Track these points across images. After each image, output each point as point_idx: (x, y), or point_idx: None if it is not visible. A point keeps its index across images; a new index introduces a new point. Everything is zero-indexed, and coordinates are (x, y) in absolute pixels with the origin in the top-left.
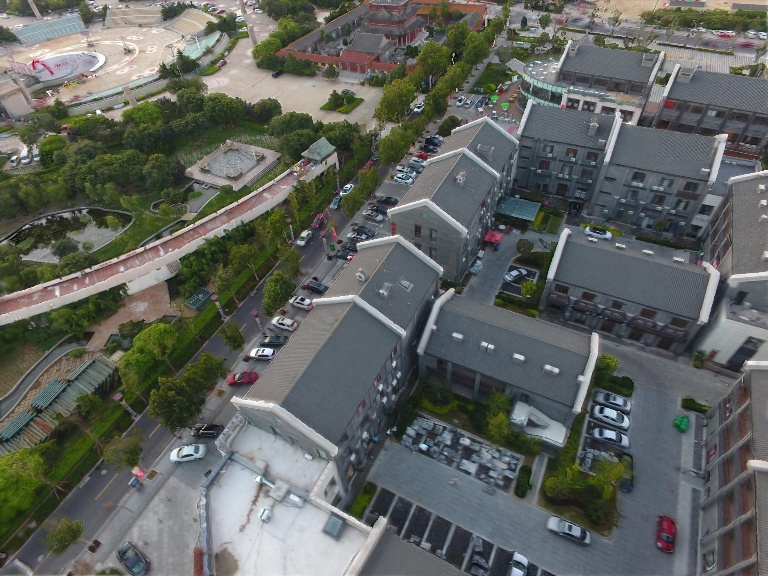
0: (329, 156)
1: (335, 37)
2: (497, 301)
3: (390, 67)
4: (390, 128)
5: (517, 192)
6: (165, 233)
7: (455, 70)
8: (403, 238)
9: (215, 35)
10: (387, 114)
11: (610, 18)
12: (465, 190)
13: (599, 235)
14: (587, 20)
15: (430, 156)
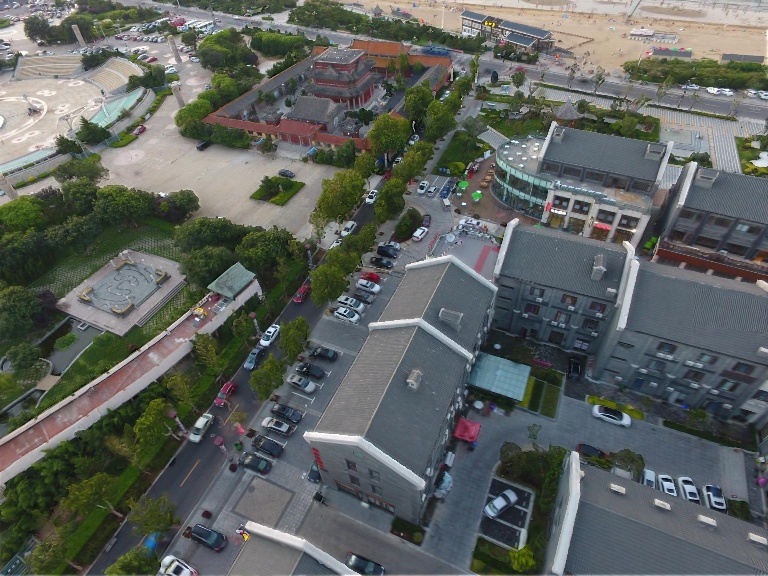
0: (246, 287)
1: (278, 95)
2: (475, 566)
3: (338, 140)
4: (334, 228)
5: (497, 337)
6: (13, 409)
7: (413, 155)
8: (312, 546)
9: (137, 92)
10: (327, 217)
11: (590, 71)
12: (421, 396)
13: (613, 420)
14: (565, 73)
15: (383, 274)
